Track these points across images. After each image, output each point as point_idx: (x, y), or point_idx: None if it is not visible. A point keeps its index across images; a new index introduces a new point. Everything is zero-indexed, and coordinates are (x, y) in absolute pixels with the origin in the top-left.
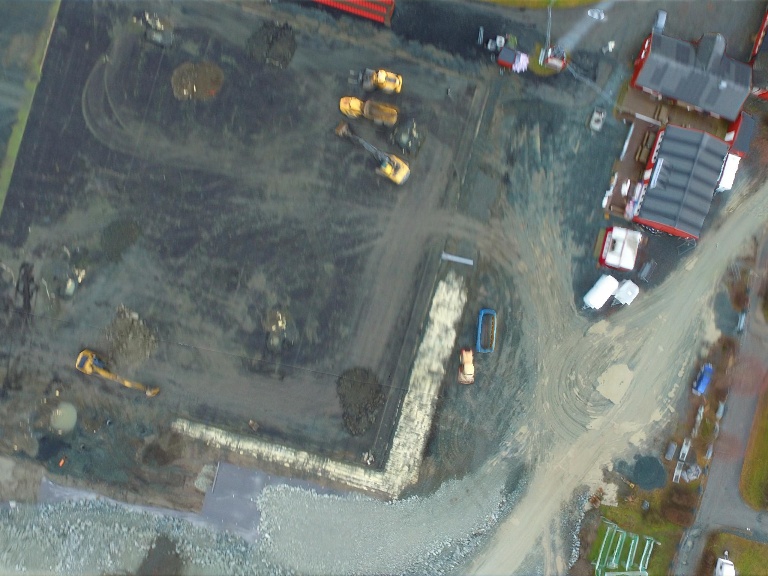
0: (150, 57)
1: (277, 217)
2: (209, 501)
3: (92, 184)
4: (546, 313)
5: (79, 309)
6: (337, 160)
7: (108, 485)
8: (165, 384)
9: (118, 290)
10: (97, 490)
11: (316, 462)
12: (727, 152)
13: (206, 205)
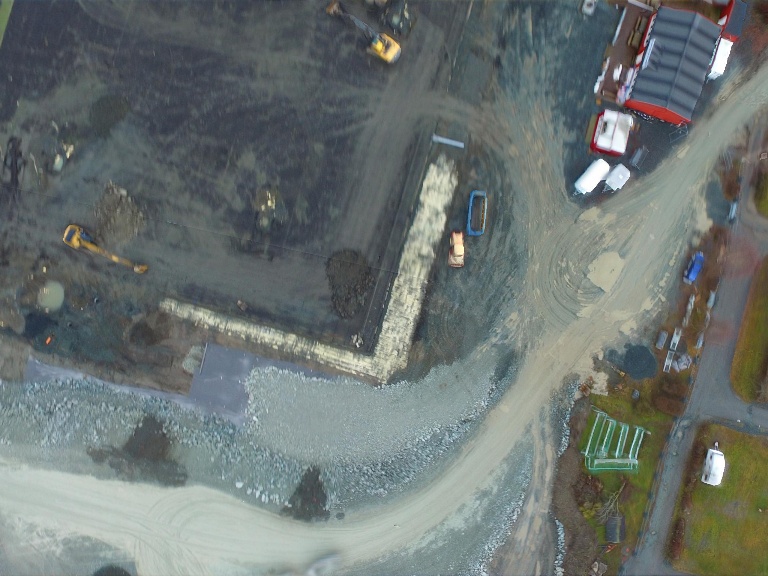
0: None
1: (267, 96)
2: (197, 383)
3: (81, 59)
4: (537, 198)
5: (67, 185)
6: (328, 39)
7: (95, 365)
8: (153, 262)
9: (106, 166)
10: (84, 370)
11: (305, 345)
12: (719, 35)
13: (196, 82)
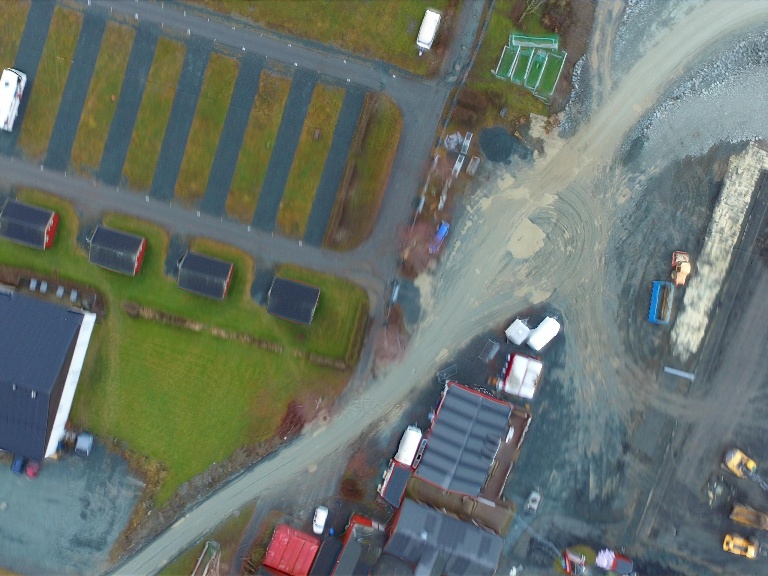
0: None
1: None
2: None
3: None
4: (594, 315)
5: None
6: None
7: None
8: None
9: None
10: None
11: None
12: (418, 468)
13: None
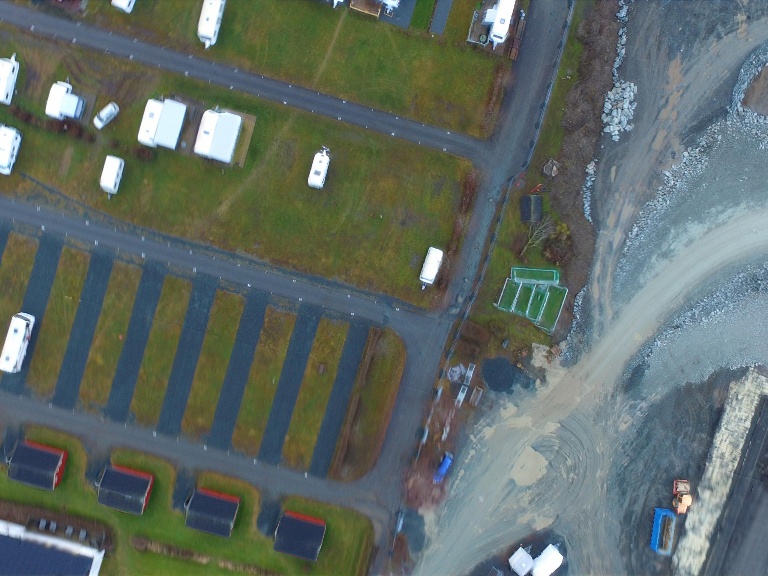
0: None
1: None
2: None
3: None
4: (597, 541)
5: None
6: None
7: None
8: None
9: None
10: None
11: None
12: None
13: None
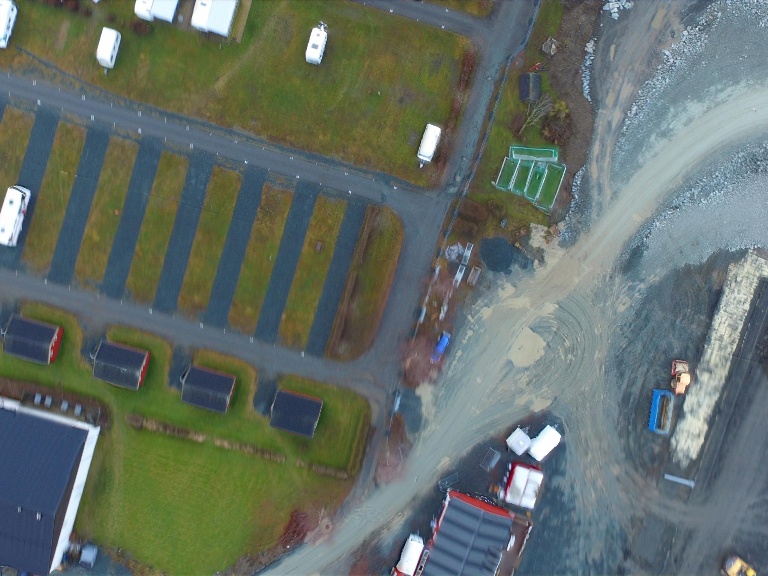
0: None
1: None
2: None
3: None
4: (595, 422)
5: None
6: None
7: None
8: None
9: None
10: None
11: None
12: None
13: None
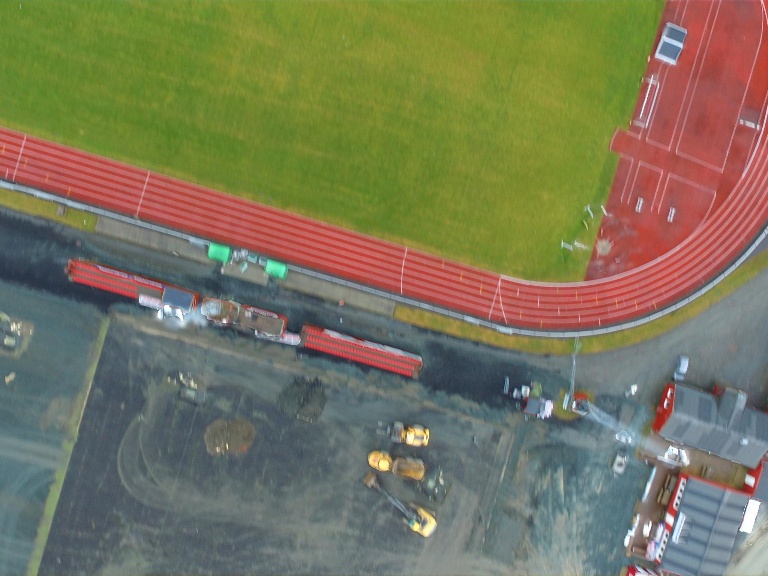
0: (184, 415)
1: (306, 566)
2: None
3: (127, 539)
4: None
5: None
6: (365, 509)
7: None
8: None
9: None
10: None
11: None
12: (748, 501)
13: (237, 556)
